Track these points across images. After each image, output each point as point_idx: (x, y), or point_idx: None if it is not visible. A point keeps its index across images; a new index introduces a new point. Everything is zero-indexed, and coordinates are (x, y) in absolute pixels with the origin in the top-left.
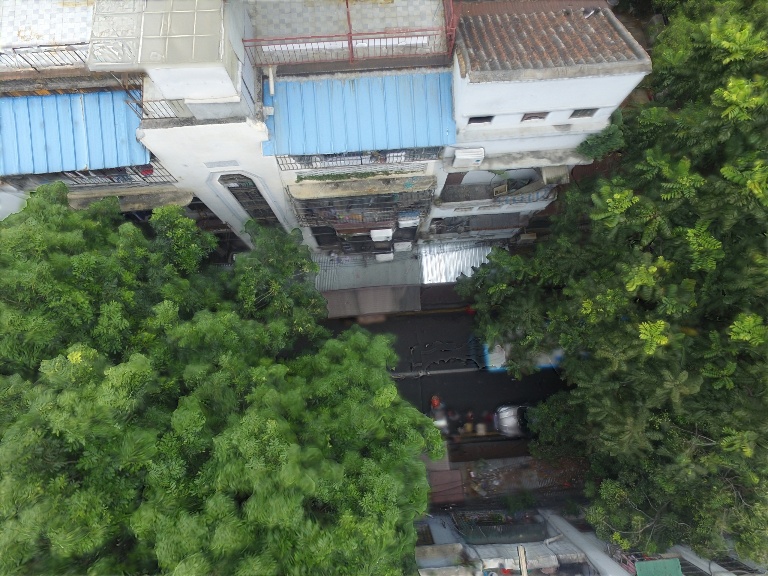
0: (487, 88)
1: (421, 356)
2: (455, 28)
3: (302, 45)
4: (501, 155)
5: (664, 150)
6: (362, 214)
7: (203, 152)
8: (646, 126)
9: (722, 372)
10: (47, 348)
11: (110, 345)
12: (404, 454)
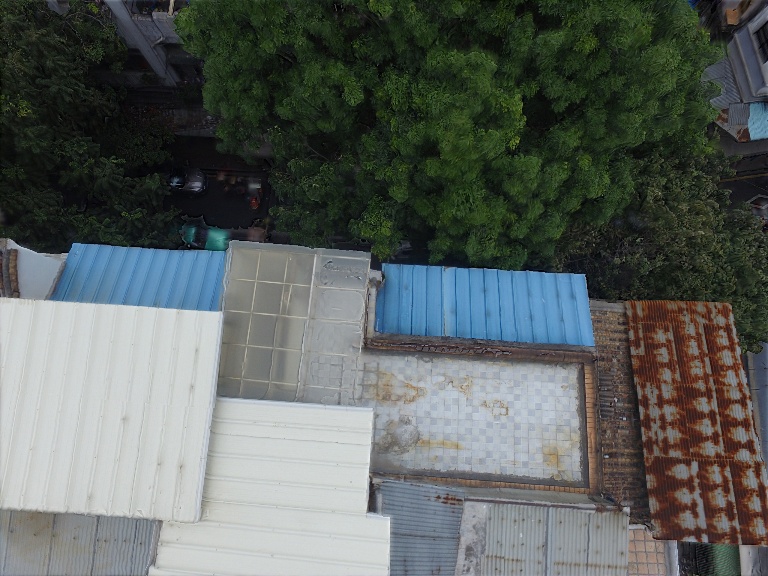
0: None
1: (254, 235)
2: None
3: None
4: None
5: None
6: None
7: None
8: None
9: None
10: None
11: None
12: None
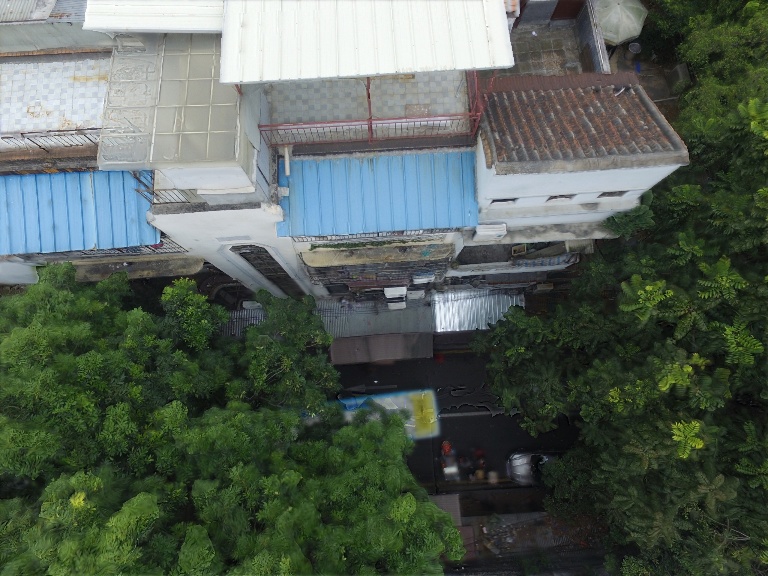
0: (514, 177)
1: (432, 402)
2: (480, 112)
3: (320, 129)
4: (523, 228)
5: (696, 231)
6: (376, 274)
7: (215, 230)
8: (677, 205)
9: (759, 470)
10: (50, 457)
11: (115, 448)
12: (422, 561)
